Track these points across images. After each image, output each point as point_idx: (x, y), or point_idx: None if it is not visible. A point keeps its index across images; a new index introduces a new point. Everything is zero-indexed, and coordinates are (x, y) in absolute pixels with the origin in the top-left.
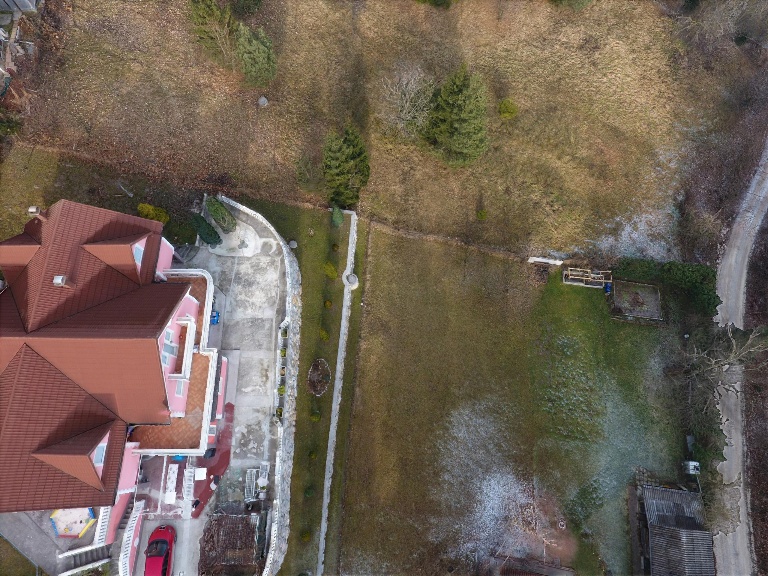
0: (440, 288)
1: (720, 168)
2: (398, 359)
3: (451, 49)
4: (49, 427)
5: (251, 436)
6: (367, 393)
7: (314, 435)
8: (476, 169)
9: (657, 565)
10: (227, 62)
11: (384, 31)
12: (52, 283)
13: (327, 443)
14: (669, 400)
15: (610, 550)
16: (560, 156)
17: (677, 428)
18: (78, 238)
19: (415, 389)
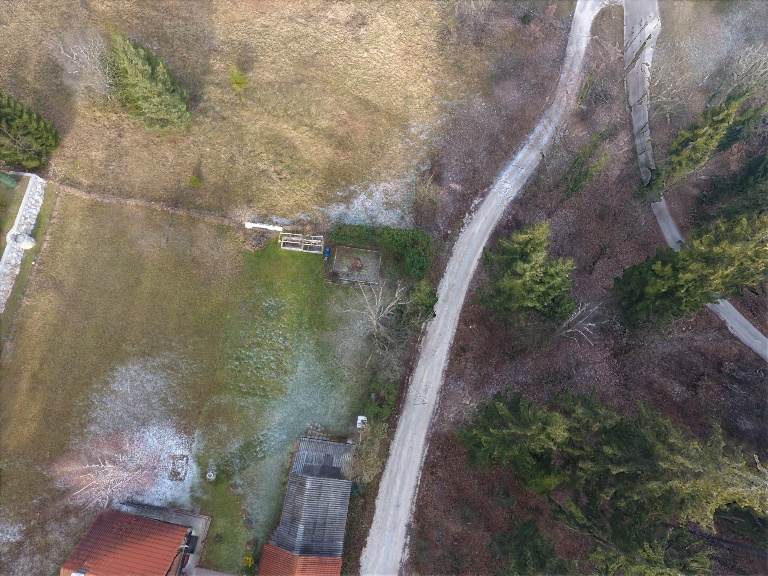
0: (135, 250)
1: (477, 140)
2: (66, 316)
3: (200, 24)
4: None
5: None
6: (21, 347)
7: None
8: (198, 138)
9: (286, 512)
10: None
11: (119, 5)
12: None
13: None
14: (364, 360)
15: (259, 500)
16: (296, 126)
17: (364, 386)
18: None
19: (79, 345)
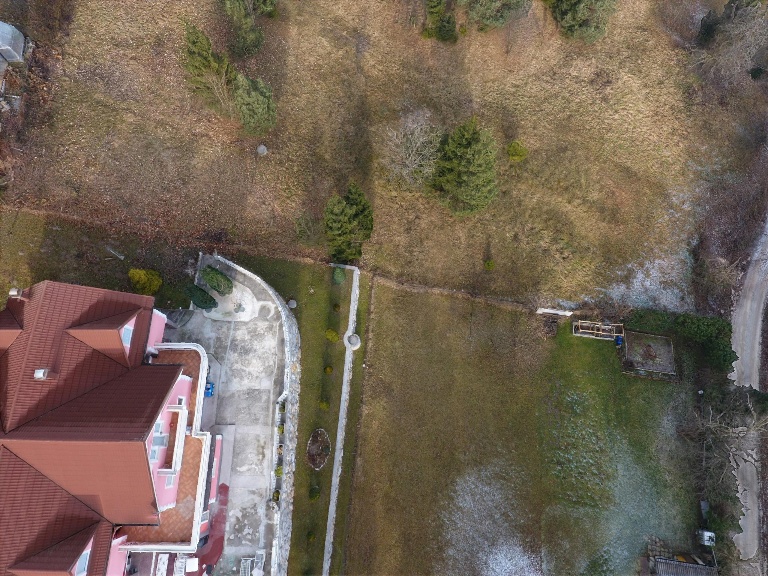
0: (445, 344)
1: (735, 209)
2: (401, 424)
3: (458, 86)
4: (28, 537)
5: (246, 521)
6: (369, 462)
7: (313, 513)
8: (483, 215)
9: None
10: (225, 110)
11: (389, 69)
12: (33, 375)
13: (326, 521)
14: (682, 462)
15: None
16: (570, 200)
17: (691, 493)
18: (62, 322)
19: (419, 456)
